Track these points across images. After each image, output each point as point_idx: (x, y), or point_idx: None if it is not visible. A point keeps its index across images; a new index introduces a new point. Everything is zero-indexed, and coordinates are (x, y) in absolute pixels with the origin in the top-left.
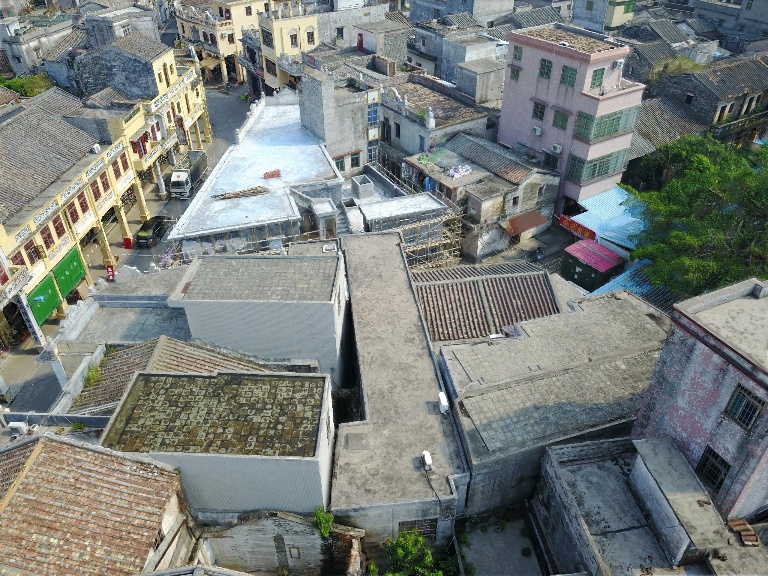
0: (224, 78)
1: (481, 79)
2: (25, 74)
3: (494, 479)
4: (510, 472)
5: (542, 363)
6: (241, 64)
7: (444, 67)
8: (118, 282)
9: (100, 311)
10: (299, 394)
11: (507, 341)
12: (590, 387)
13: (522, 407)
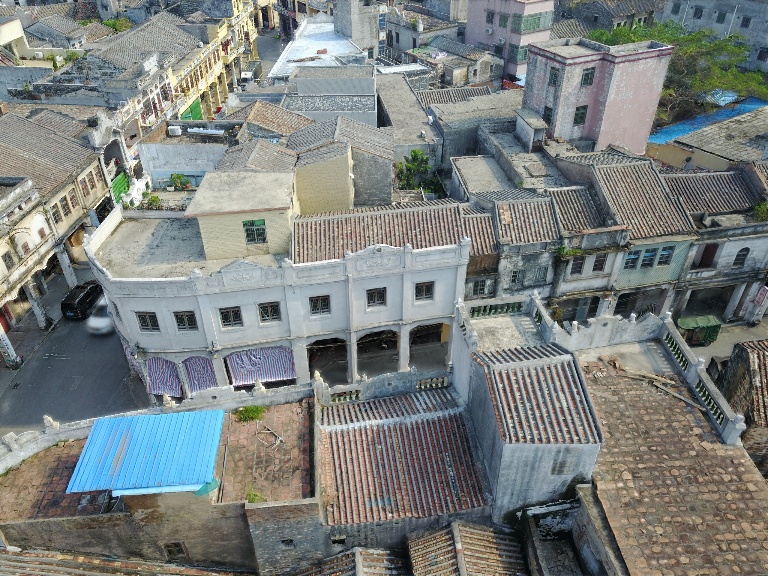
0: (260, 24)
1: (453, 3)
2: (111, 19)
3: (455, 145)
4: (462, 143)
5: (480, 107)
6: (276, 10)
7: (428, 5)
8: (247, 91)
9: (241, 102)
10: (364, 99)
11: (463, 102)
12: (503, 113)
13: (469, 118)
